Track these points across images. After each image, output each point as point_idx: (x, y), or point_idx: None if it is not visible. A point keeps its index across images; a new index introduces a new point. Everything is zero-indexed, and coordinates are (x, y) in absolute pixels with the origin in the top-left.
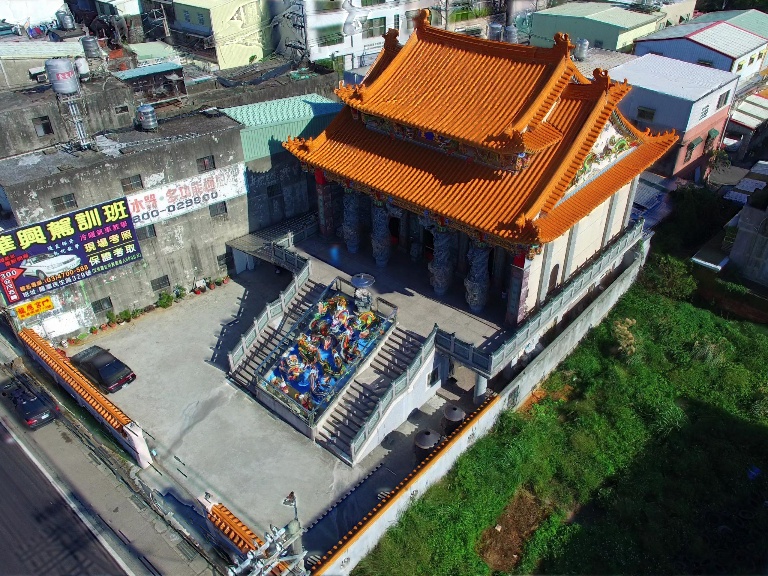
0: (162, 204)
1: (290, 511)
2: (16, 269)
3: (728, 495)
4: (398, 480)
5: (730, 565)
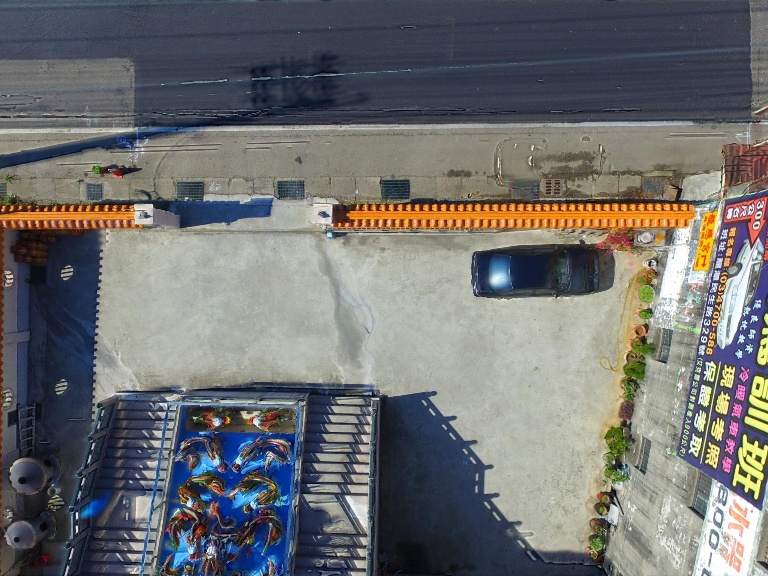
0: (721, 569)
1: (132, 296)
2: (761, 231)
3: None
4: (62, 415)
5: None
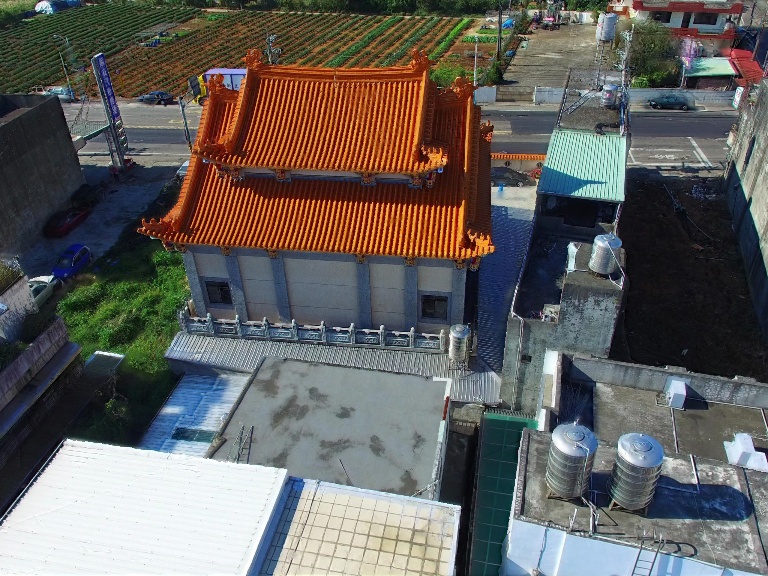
0: None
1: None
2: None
3: (133, 254)
4: None
5: (141, 218)
